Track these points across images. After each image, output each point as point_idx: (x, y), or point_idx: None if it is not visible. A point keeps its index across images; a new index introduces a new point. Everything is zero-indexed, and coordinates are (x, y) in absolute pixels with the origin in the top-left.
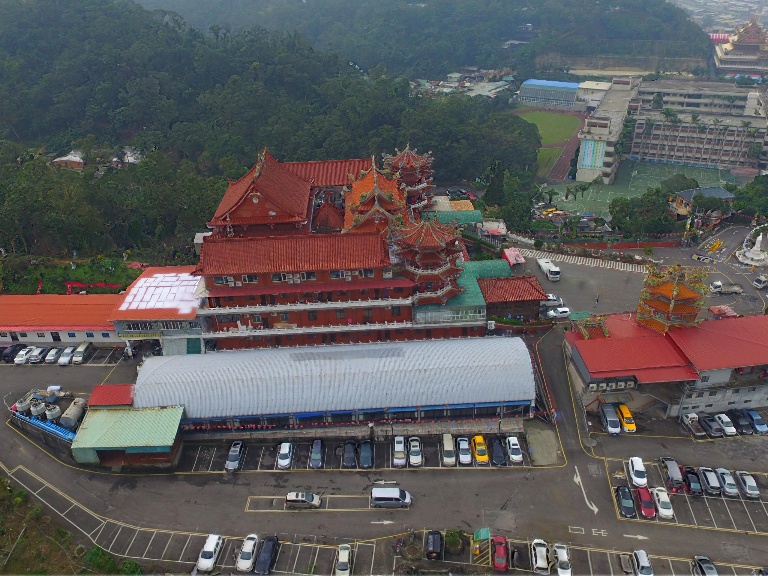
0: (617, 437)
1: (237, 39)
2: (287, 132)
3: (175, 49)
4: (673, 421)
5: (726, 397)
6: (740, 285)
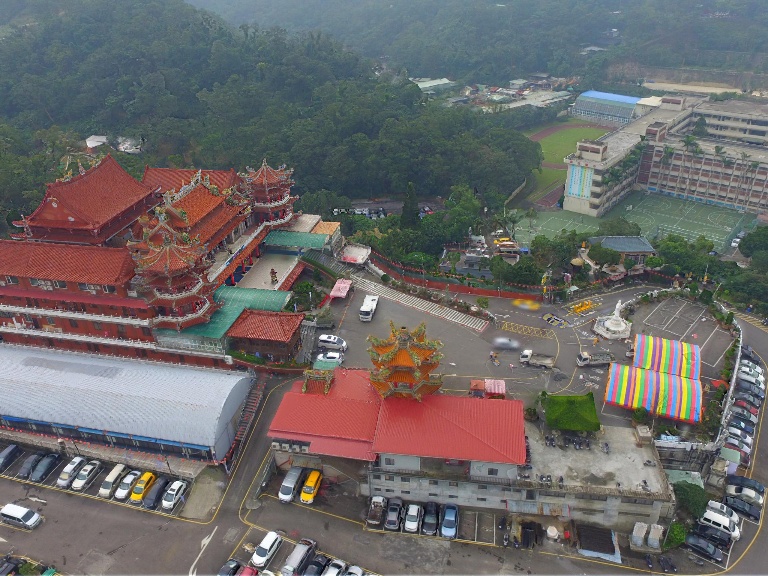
0: (286, 505)
1: (257, 39)
2: (262, 133)
3: (197, 46)
4: (363, 501)
5: (424, 486)
6: (563, 358)
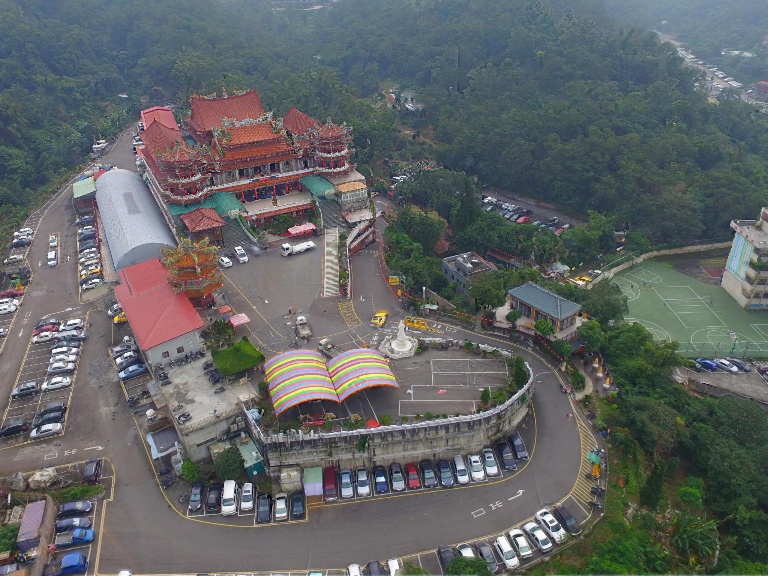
0: None
1: None
2: None
3: None
4: None
5: None
6: None
